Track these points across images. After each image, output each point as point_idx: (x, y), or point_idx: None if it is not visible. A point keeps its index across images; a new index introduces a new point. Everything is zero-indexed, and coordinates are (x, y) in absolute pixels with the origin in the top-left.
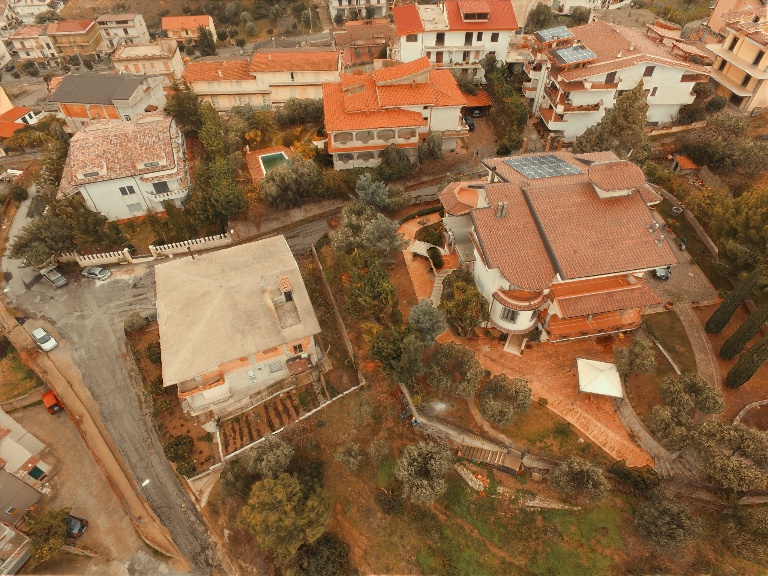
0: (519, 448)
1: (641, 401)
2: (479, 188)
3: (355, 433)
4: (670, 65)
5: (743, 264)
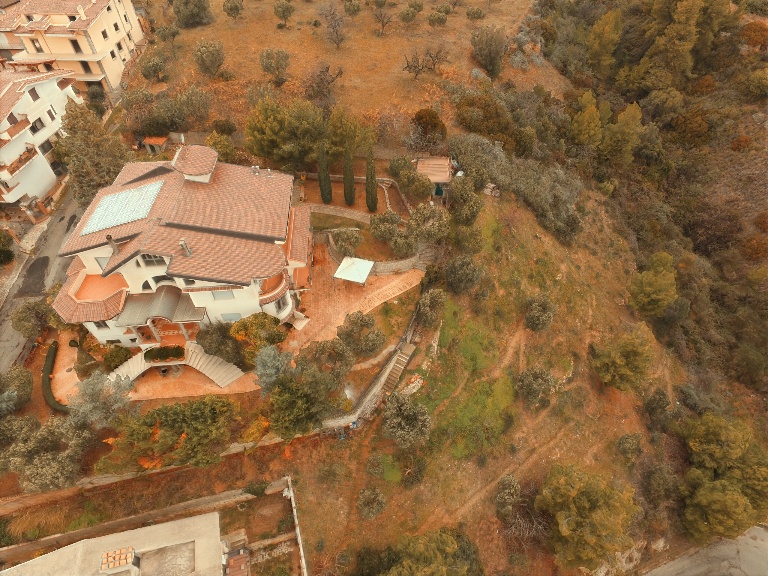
0: (396, 343)
1: (376, 256)
2: (129, 260)
3: (342, 500)
4: (45, 79)
5: (298, 154)
